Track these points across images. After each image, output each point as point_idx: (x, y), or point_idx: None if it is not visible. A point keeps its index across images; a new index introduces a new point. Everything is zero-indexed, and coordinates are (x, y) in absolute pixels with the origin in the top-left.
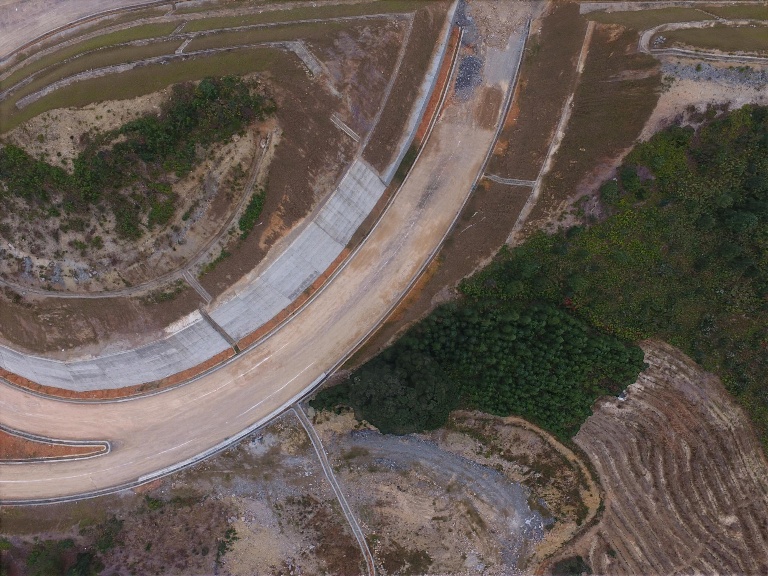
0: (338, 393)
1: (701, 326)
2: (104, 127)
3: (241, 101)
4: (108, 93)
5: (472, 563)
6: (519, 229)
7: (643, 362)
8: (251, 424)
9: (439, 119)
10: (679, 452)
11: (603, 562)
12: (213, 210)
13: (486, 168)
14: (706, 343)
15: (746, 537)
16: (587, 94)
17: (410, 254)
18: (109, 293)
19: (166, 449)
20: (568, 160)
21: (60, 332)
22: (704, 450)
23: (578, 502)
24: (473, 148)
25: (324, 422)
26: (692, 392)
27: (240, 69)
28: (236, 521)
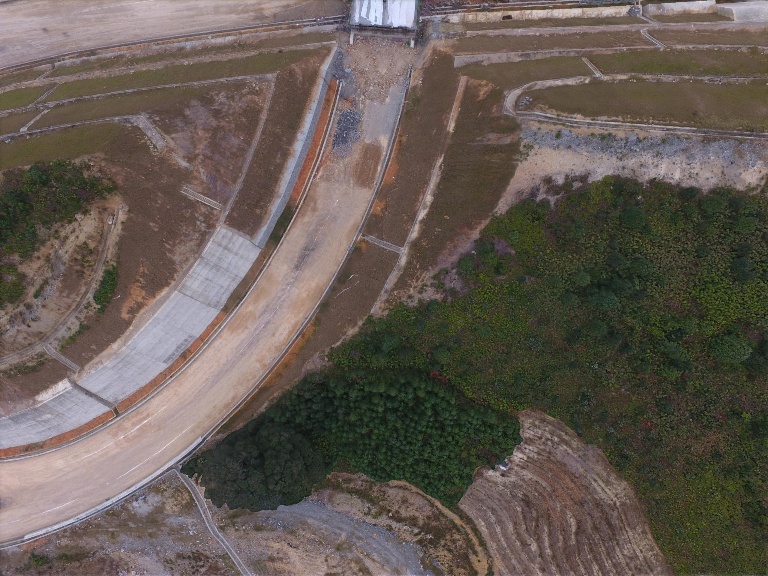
0: None
1: (578, 399)
2: None
3: (74, 184)
4: None
5: None
6: (385, 298)
7: (518, 435)
8: (131, 486)
9: (316, 177)
10: (563, 524)
11: None
12: (64, 287)
13: (363, 228)
14: (587, 415)
15: None
16: (455, 156)
17: (286, 317)
18: None
19: (50, 508)
20: (434, 227)
21: None
22: (589, 523)
23: (468, 566)
24: (351, 207)
25: None
26: (575, 464)
27: (72, 151)
28: (127, 574)
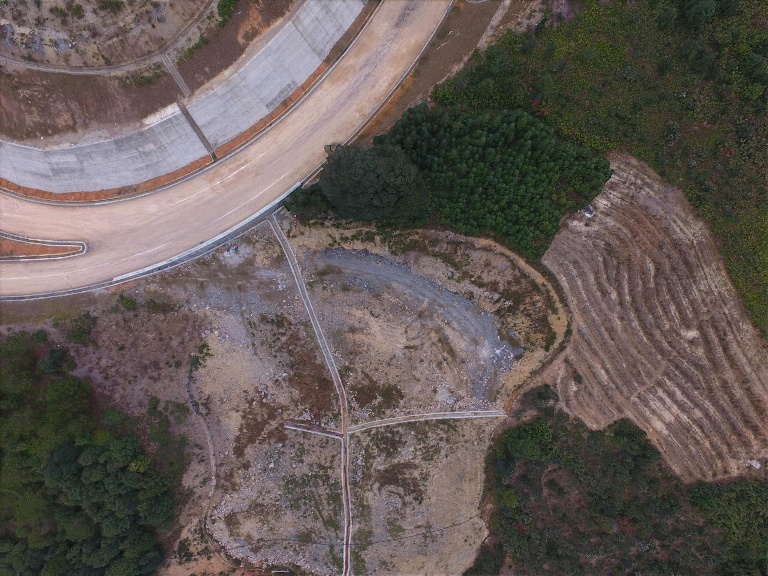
0: (311, 191)
1: (664, 134)
2: None
3: None
4: None
5: (443, 397)
6: (490, 34)
7: (608, 170)
8: (226, 229)
9: None
10: (643, 267)
11: (570, 389)
12: None
13: None
14: (670, 155)
15: (707, 352)
16: None
17: (386, 71)
18: (88, 70)
19: (142, 251)
20: None
21: (39, 114)
22: (667, 265)
23: (546, 327)
24: None
25: (299, 236)
26: (656, 207)
27: None
28: (210, 336)
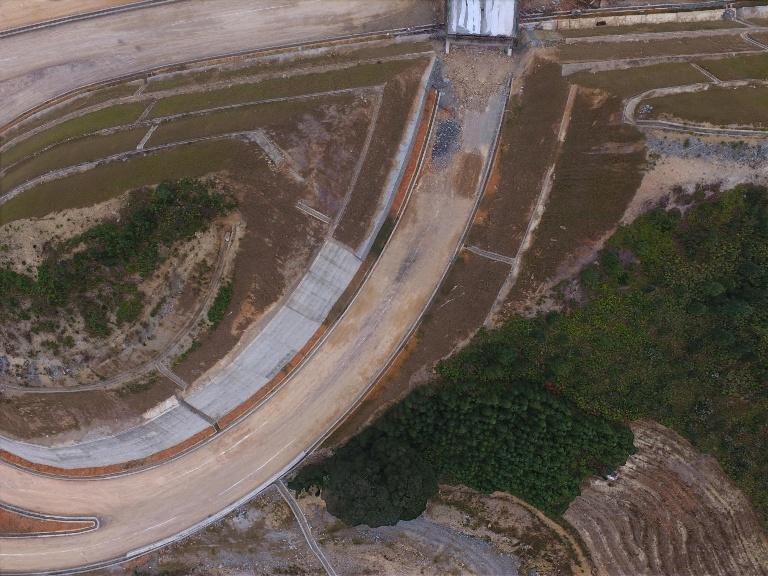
0: (315, 477)
1: (695, 409)
2: (65, 235)
3: (200, 202)
4: (68, 200)
5: None
6: (497, 310)
7: (633, 445)
8: (233, 502)
9: (416, 188)
10: (674, 534)
11: None
12: (180, 305)
13: (466, 239)
14: (702, 424)
15: None
16: (569, 166)
17: (388, 330)
18: (85, 387)
19: (152, 525)
20: (548, 238)
21: (42, 421)
22: (701, 532)
23: None
24: (452, 218)
25: (307, 497)
26: (687, 473)
27: (197, 169)
28: None
